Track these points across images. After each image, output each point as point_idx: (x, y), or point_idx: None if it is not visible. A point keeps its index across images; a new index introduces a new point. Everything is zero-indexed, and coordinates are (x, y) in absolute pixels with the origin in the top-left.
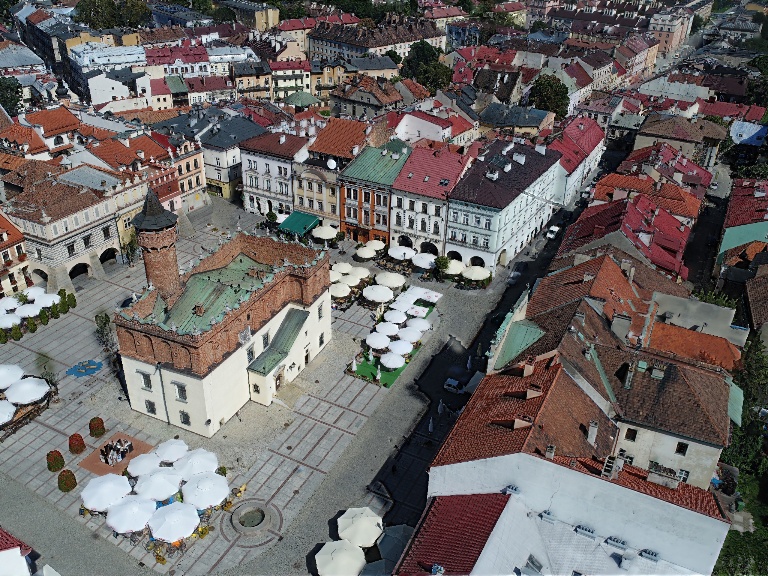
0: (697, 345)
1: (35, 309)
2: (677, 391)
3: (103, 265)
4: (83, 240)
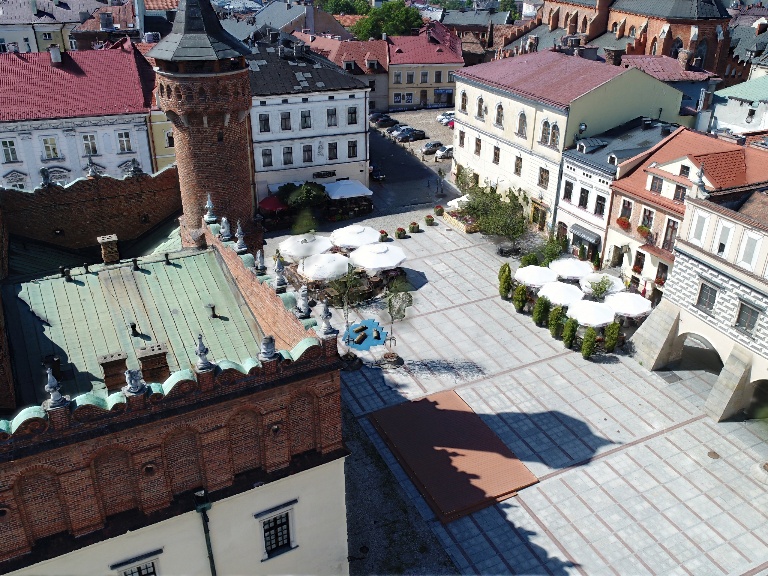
0: None
1: (555, 294)
2: None
3: None
4: (742, 305)
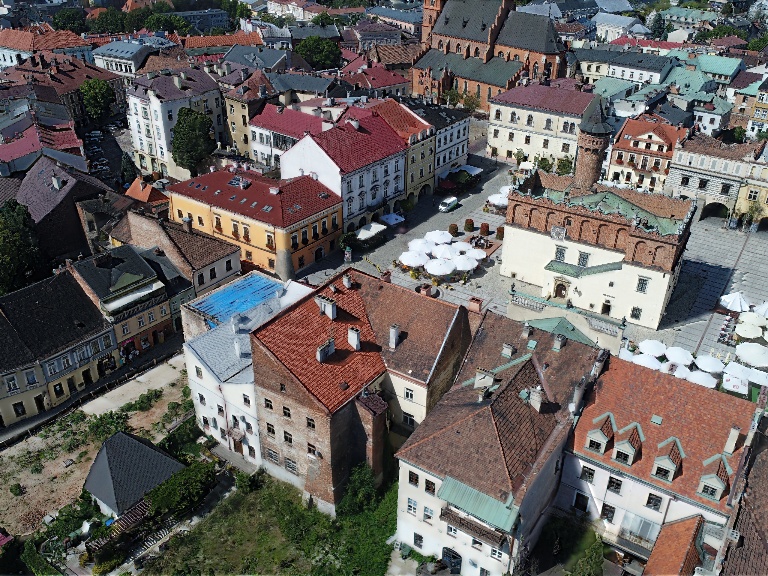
0: (663, 569)
1: None
2: (461, 413)
3: (718, 218)
4: (700, 180)
